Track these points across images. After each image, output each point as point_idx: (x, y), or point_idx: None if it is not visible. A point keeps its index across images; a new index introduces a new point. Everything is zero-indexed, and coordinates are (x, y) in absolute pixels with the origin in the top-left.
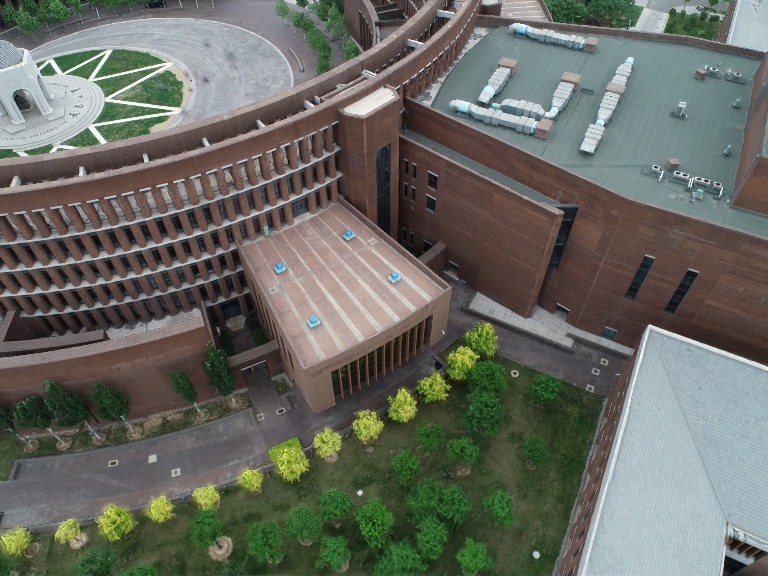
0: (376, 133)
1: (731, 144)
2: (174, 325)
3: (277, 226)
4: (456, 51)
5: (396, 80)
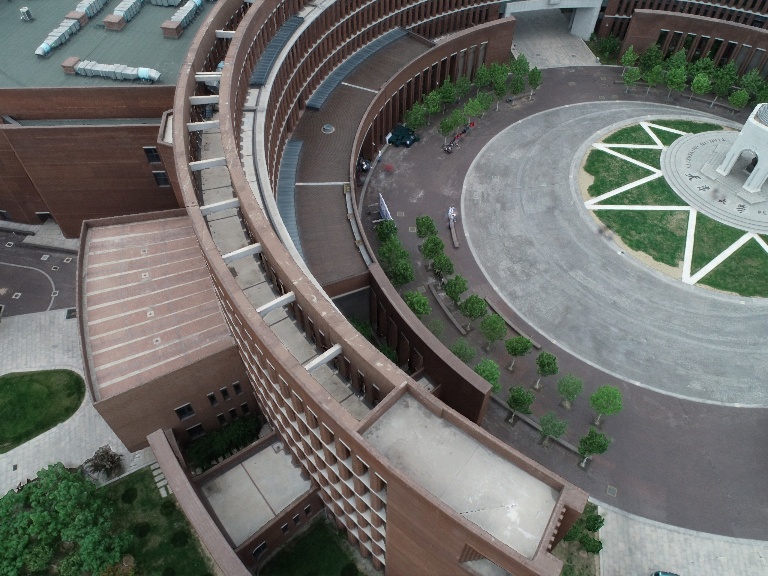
0: None
1: (1, 7)
2: None
3: None
4: None
5: None
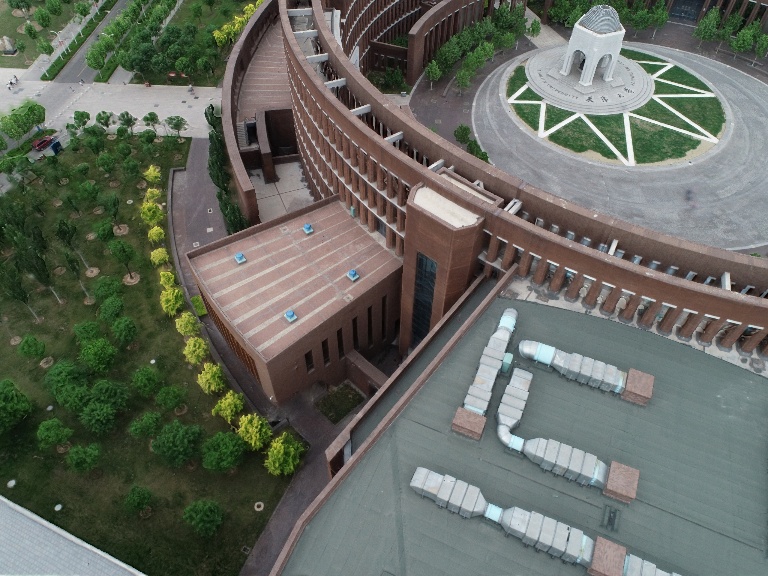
0: (420, 233)
1: None
2: (247, 175)
3: (361, 219)
4: (665, 322)
5: (503, 230)
